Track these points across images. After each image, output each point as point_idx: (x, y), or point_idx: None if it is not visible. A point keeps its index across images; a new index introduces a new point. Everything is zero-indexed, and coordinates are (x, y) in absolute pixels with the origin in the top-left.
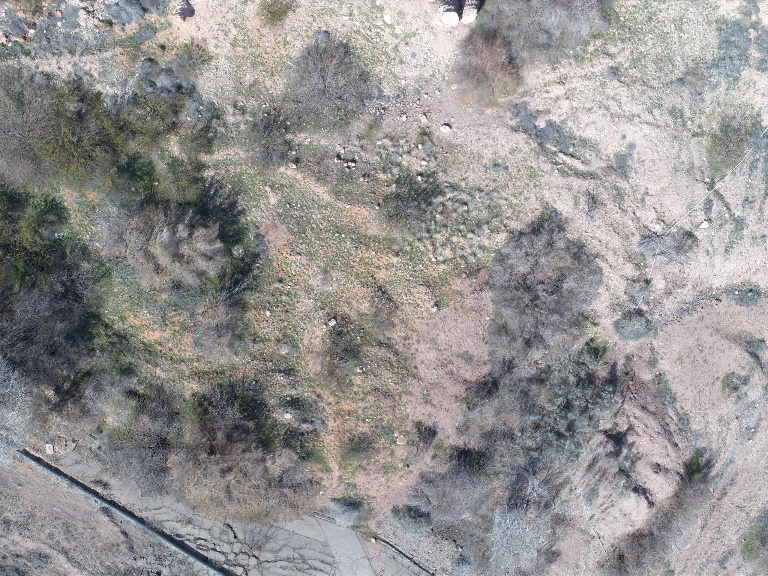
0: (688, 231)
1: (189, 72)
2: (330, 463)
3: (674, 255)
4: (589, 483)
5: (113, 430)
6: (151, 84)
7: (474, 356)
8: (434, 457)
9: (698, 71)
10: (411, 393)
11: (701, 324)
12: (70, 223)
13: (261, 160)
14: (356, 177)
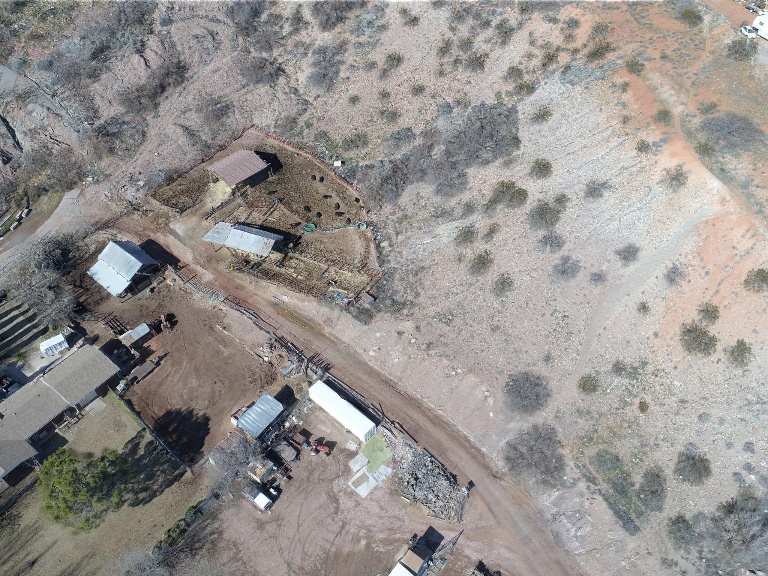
0: None
1: None
2: (22, 39)
3: None
4: None
5: None
6: None
7: (100, 23)
8: None
9: None
10: None
11: (191, 22)
12: None
13: None
14: None
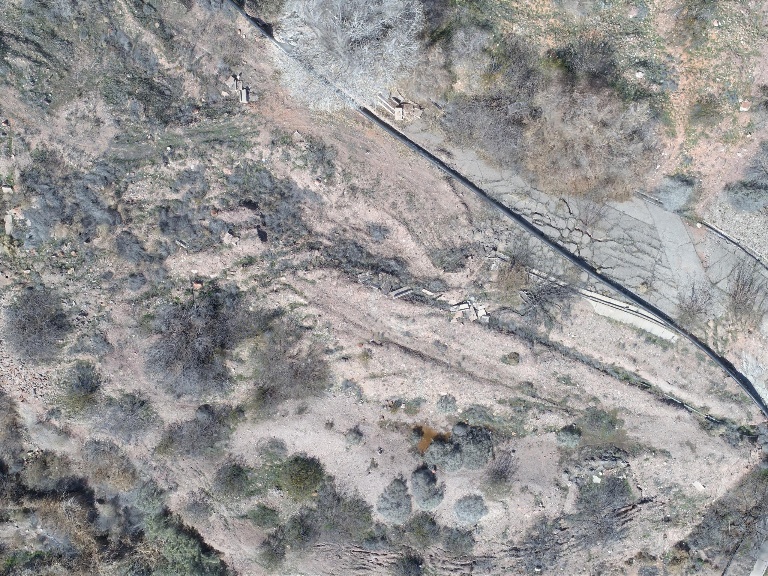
0: None
1: None
2: (677, 126)
3: None
4: None
5: (459, 97)
6: None
7: None
8: None
9: None
10: (760, 54)
11: None
12: None
13: None
14: None
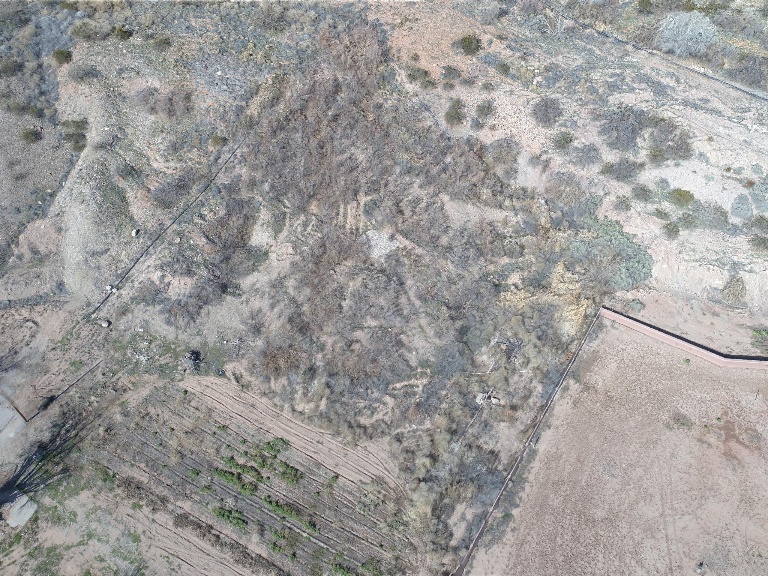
0: None
1: (726, 3)
2: None
3: None
4: None
5: (727, 69)
6: None
7: None
8: None
9: None
10: None
11: None
12: None
13: (763, 16)
14: None
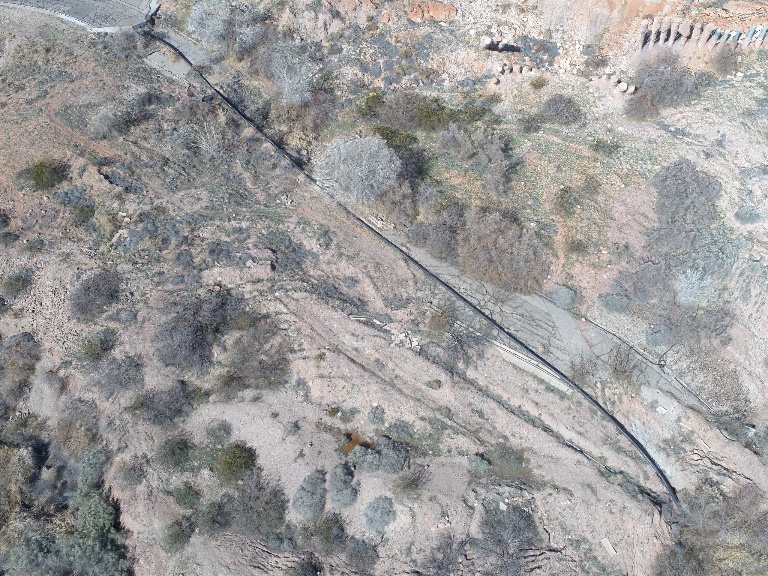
0: (766, 165)
1: (490, 105)
2: (558, 252)
3: (762, 176)
4: (742, 287)
5: (420, 223)
6: None
7: (648, 217)
8: (628, 262)
9: (750, 112)
10: (610, 227)
11: None
12: (418, 143)
13: (524, 130)
14: None
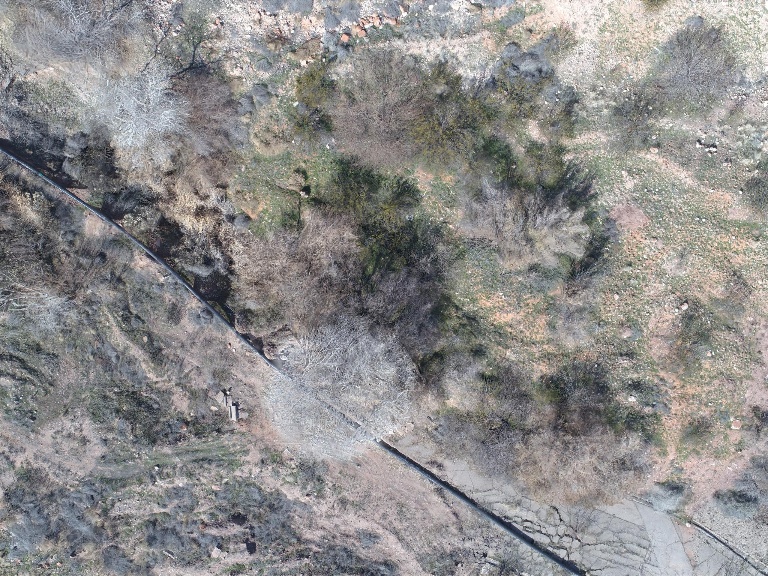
0: None
1: (551, 56)
2: (668, 447)
3: None
4: None
5: (451, 411)
6: (514, 68)
7: None
8: (767, 442)
9: None
10: (752, 378)
11: None
12: (422, 205)
13: (621, 144)
14: (719, 162)
